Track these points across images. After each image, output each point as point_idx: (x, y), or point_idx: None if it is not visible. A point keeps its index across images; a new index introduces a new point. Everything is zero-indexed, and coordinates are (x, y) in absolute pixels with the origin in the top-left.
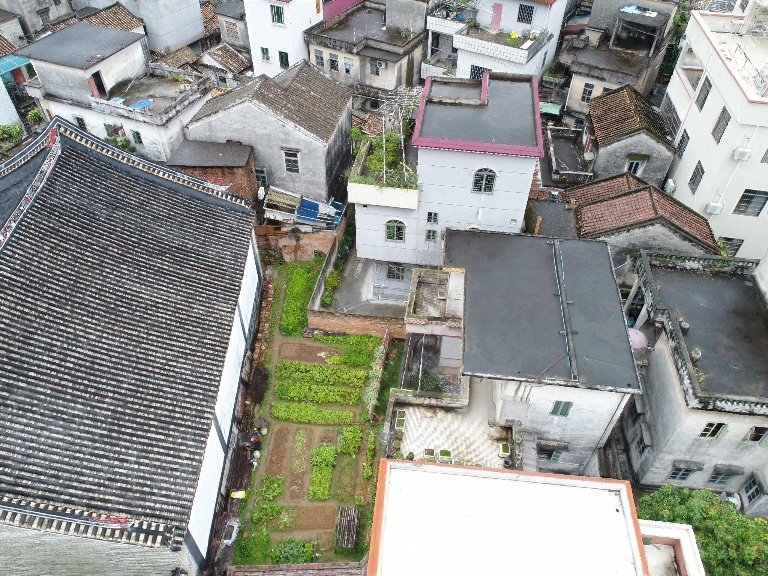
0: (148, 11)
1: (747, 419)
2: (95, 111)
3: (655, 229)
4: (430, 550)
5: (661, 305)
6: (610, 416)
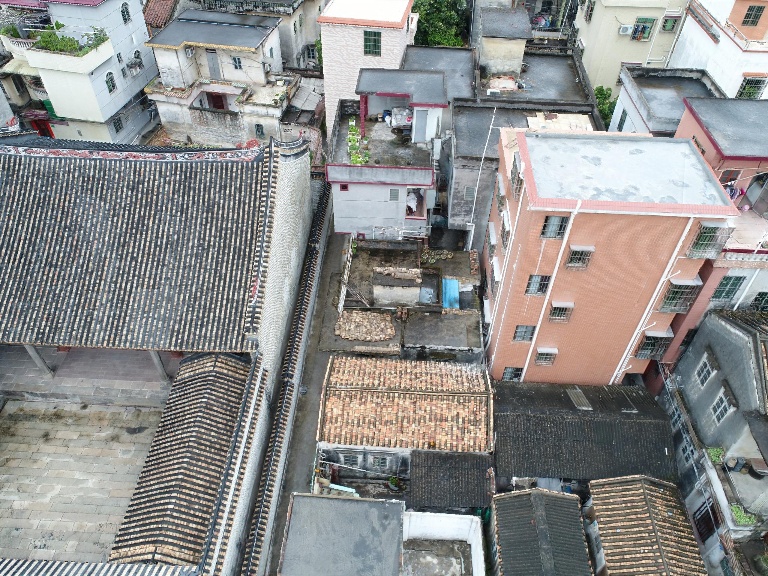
0: None
1: (297, 13)
2: None
3: (181, 1)
4: (354, 14)
5: (241, 1)
6: (279, 46)
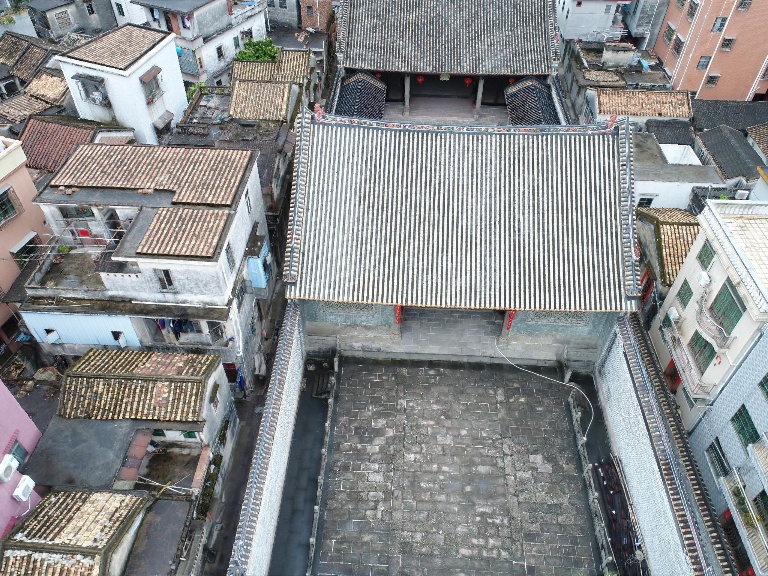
0: (25, 29)
1: None
2: (233, 27)
3: None
4: None
5: None
6: None
